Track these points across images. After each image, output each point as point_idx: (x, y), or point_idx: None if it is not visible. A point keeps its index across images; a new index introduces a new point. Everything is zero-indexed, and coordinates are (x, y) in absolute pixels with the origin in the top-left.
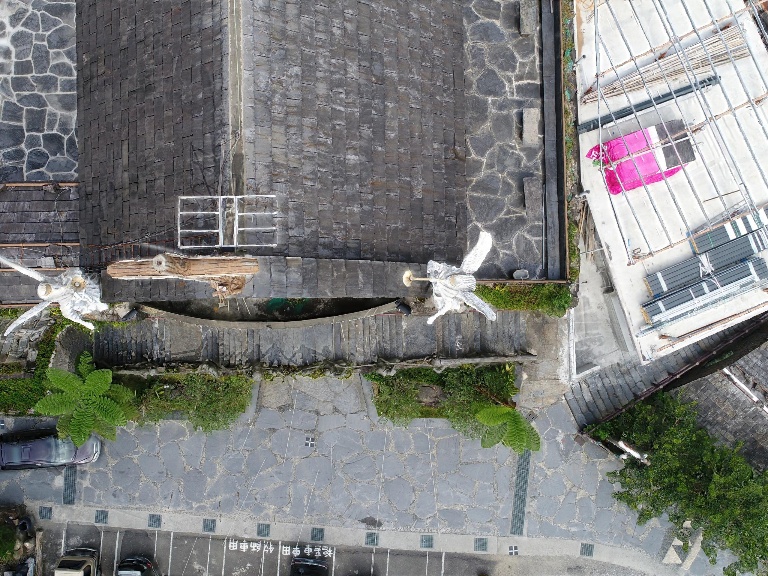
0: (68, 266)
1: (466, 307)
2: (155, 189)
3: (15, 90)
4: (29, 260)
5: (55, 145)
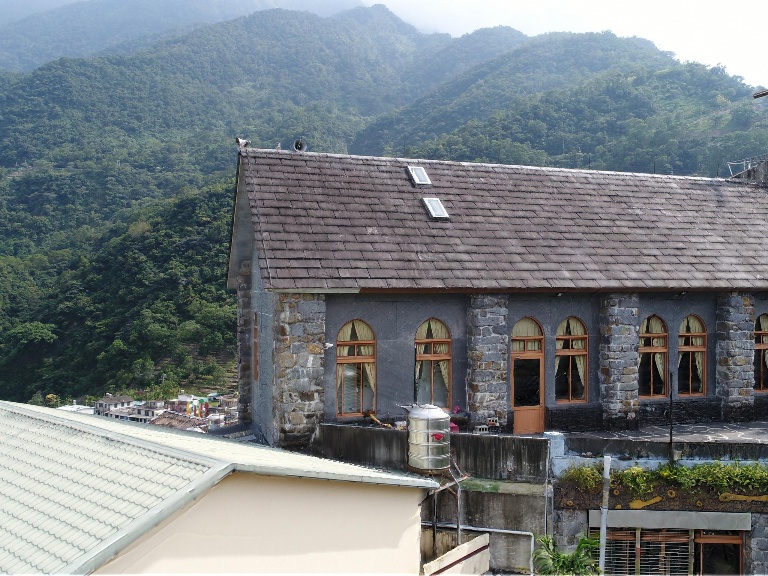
0: None
1: None
2: None
3: None
4: None
5: None
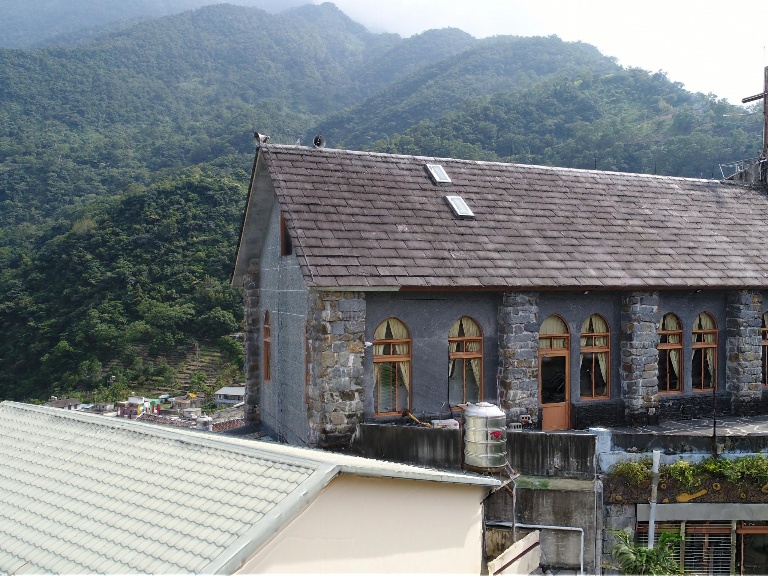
0: None
1: None
2: None
3: None
4: None
5: None
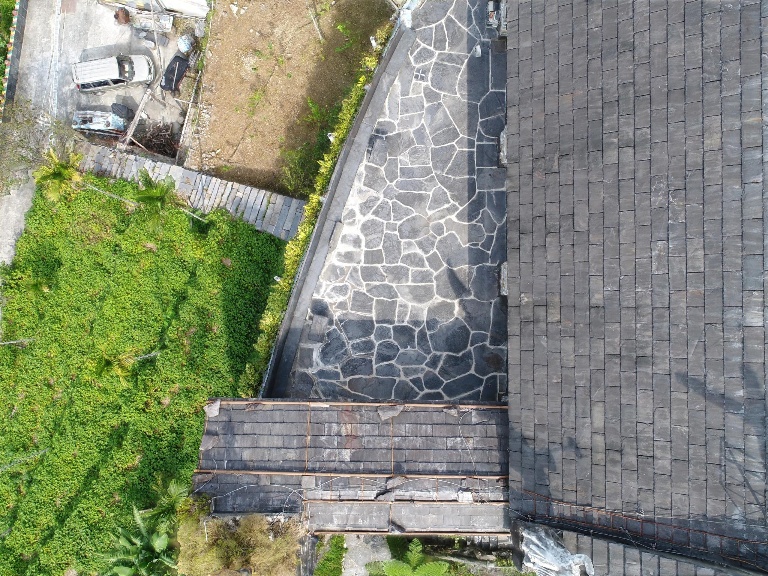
0: (486, 501)
1: None
2: (655, 468)
3: (365, 280)
4: (445, 493)
5: (406, 337)
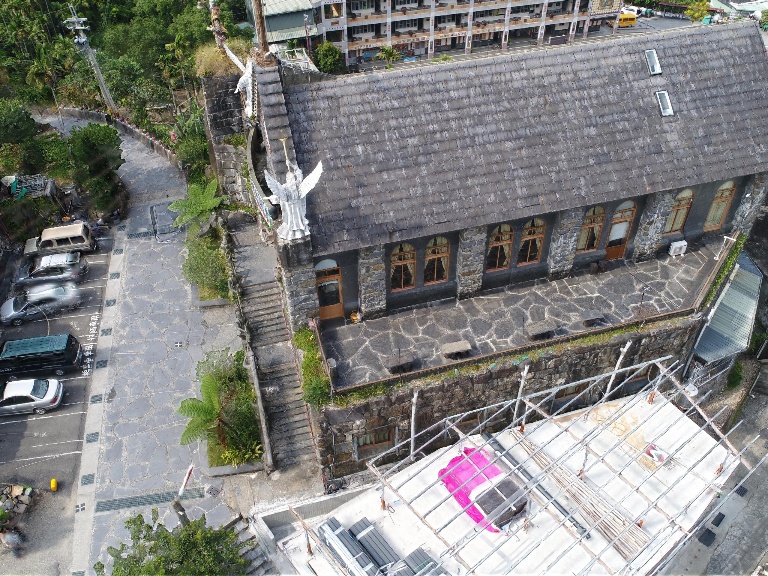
0: None
1: (283, 245)
2: None
3: None
4: None
5: None
